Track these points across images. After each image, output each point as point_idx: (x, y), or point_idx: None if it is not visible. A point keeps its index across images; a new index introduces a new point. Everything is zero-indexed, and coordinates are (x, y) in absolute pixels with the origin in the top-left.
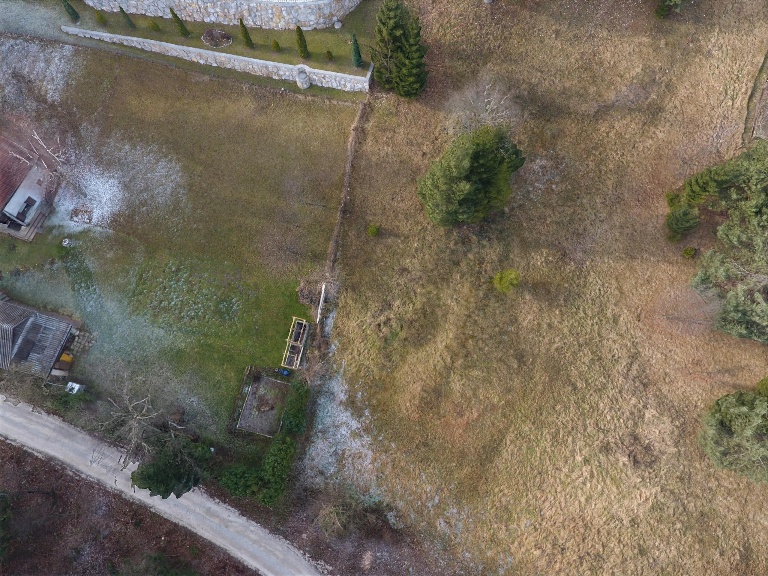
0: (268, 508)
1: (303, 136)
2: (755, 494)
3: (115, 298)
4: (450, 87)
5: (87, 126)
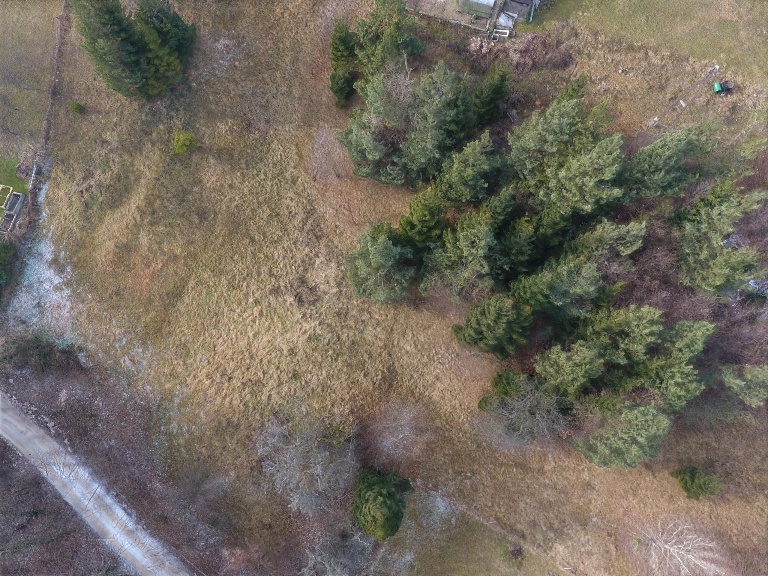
0: None
1: (18, 27)
2: (400, 323)
3: None
4: None
5: None
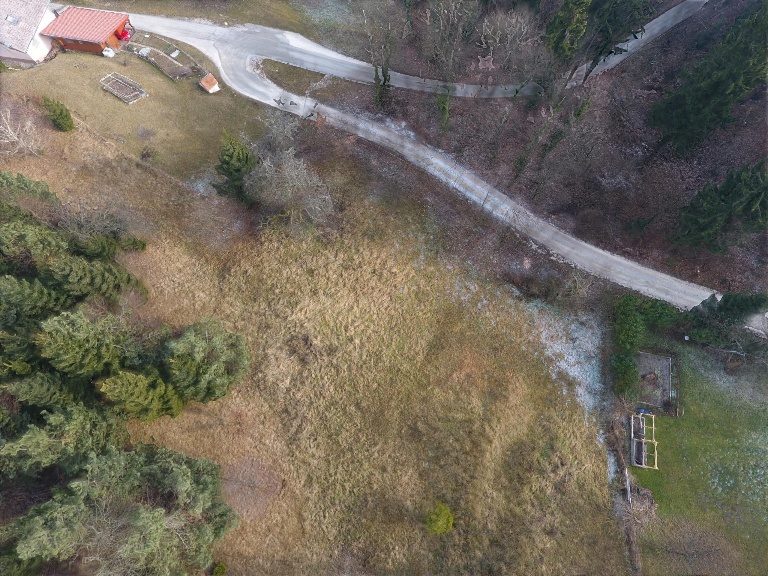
0: None
1: None
2: None
3: None
4: None
5: None
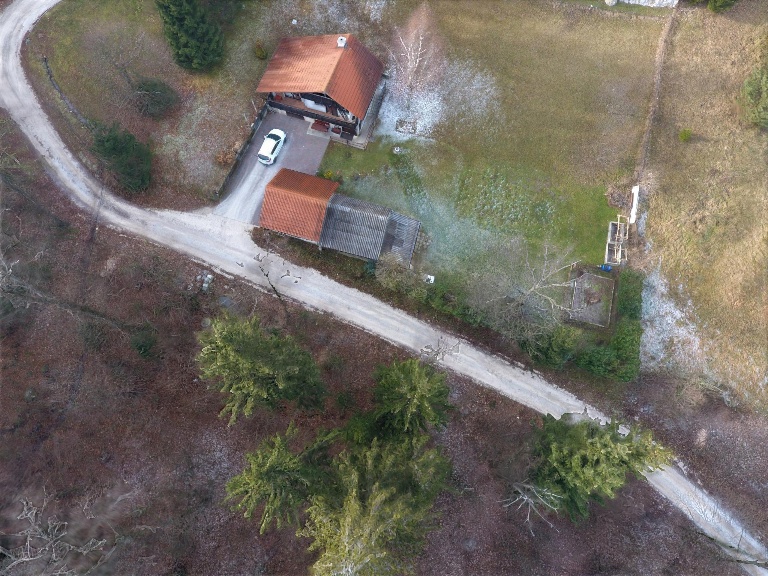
0: (602, 392)
1: (610, 50)
2: None
3: (443, 202)
4: (754, 1)
5: (408, 43)
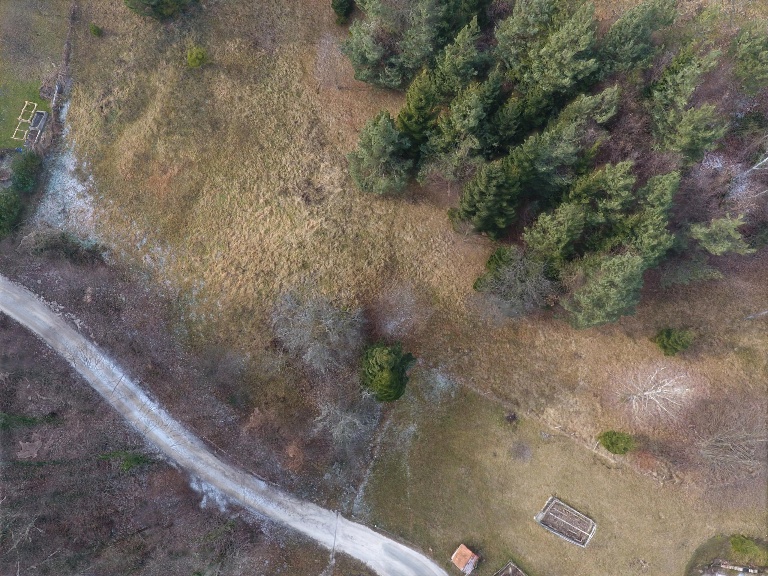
0: (7, 259)
1: None
2: (400, 217)
3: None
4: None
5: None
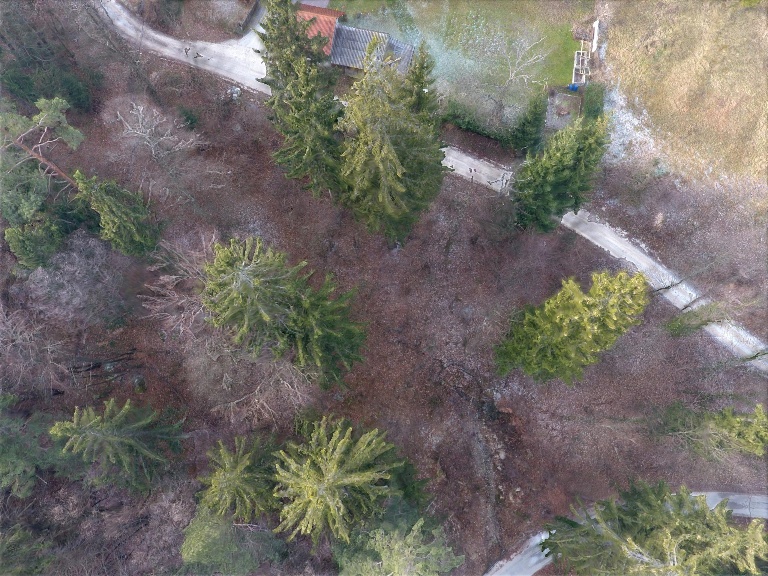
0: None
1: None
2: None
3: (433, 37)
4: None
5: None
